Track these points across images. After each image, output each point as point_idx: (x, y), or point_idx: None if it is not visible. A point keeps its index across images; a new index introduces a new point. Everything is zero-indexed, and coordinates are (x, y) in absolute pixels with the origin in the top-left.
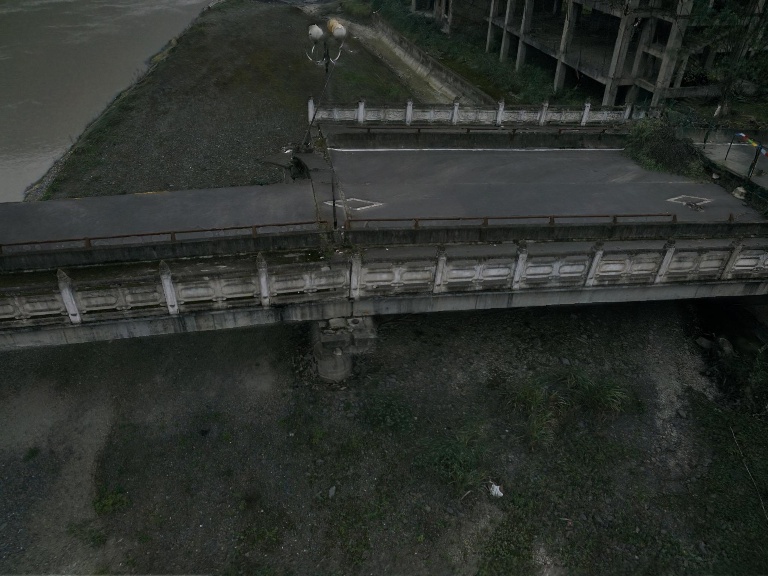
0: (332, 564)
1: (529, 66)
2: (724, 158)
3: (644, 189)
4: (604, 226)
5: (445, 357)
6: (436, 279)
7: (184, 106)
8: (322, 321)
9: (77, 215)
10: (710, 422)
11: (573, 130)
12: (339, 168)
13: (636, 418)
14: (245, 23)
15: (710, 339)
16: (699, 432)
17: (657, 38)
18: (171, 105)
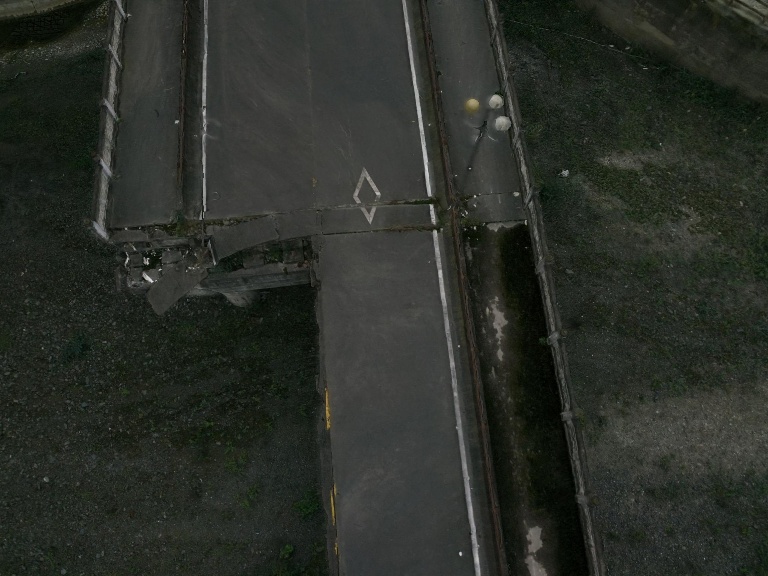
0: (617, 274)
1: None
2: None
3: None
4: (426, 1)
5: None
6: None
7: None
8: None
9: (380, 478)
10: (509, 30)
11: None
12: (268, 208)
13: None
14: None
15: None
16: (510, 40)
17: None
18: None
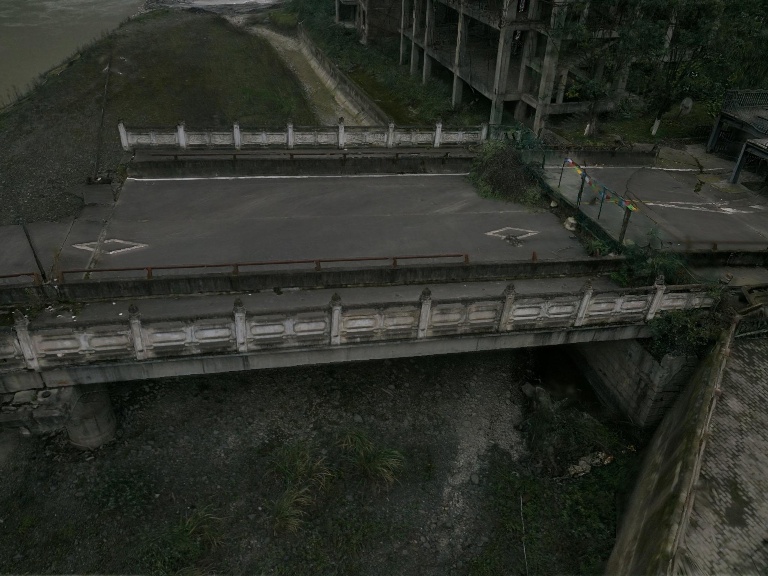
0: None
1: (434, 79)
2: (565, 184)
3: (466, 221)
4: (382, 270)
5: (222, 416)
6: (135, 344)
7: (52, 125)
8: (8, 394)
9: None
10: (498, 491)
11: (412, 154)
12: (123, 202)
13: (419, 486)
14: (161, 34)
15: (535, 385)
16: (486, 502)
17: (540, 52)
18: (39, 124)
